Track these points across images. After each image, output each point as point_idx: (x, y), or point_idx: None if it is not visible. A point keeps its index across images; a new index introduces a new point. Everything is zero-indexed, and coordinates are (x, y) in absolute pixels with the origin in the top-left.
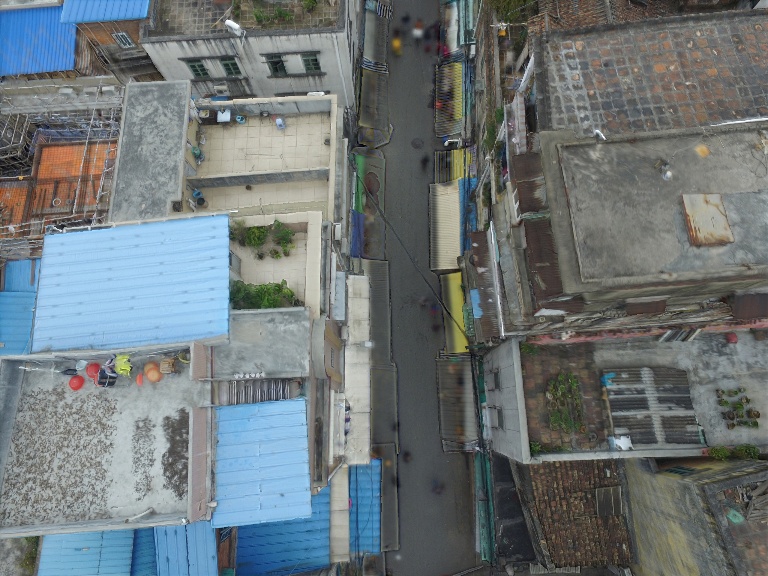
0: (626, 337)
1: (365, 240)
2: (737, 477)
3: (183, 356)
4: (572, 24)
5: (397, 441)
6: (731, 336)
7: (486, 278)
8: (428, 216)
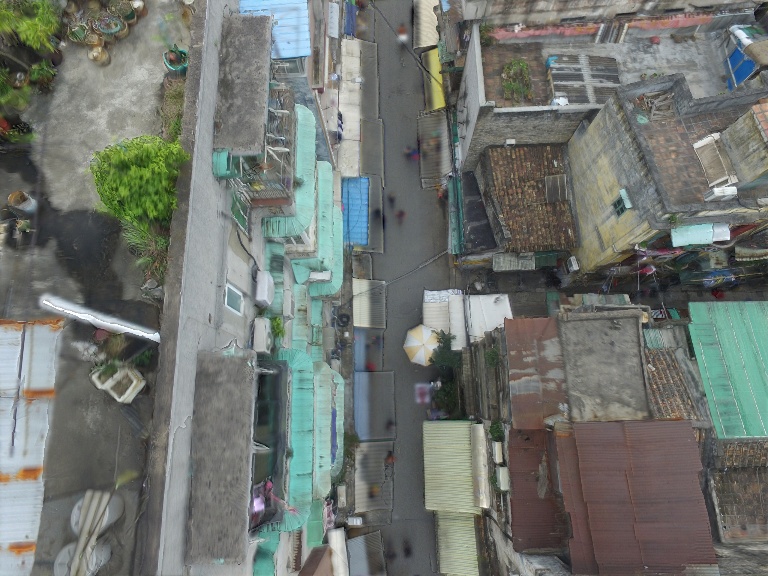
0: (568, 34)
1: (357, 26)
2: (642, 81)
3: None
4: None
5: (383, 177)
6: (654, 38)
7: None
8: (412, 10)
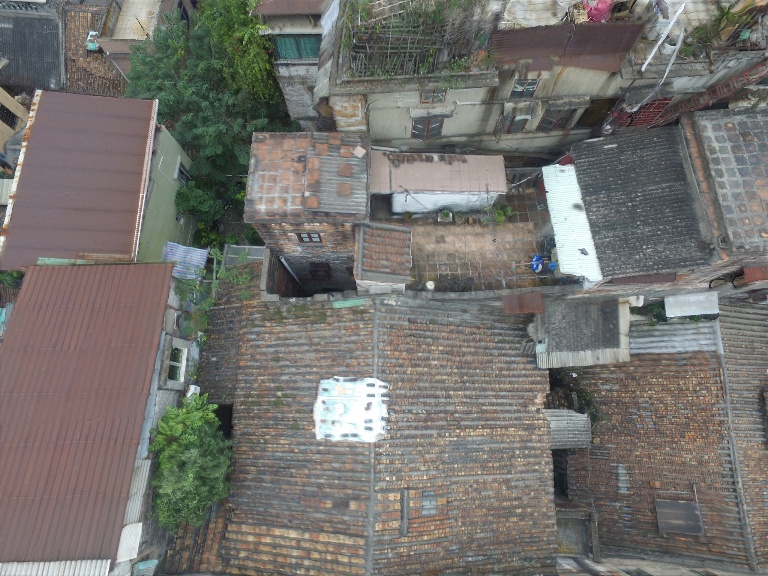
0: None
1: None
2: None
3: None
4: (765, 464)
5: None
6: None
7: None
8: None
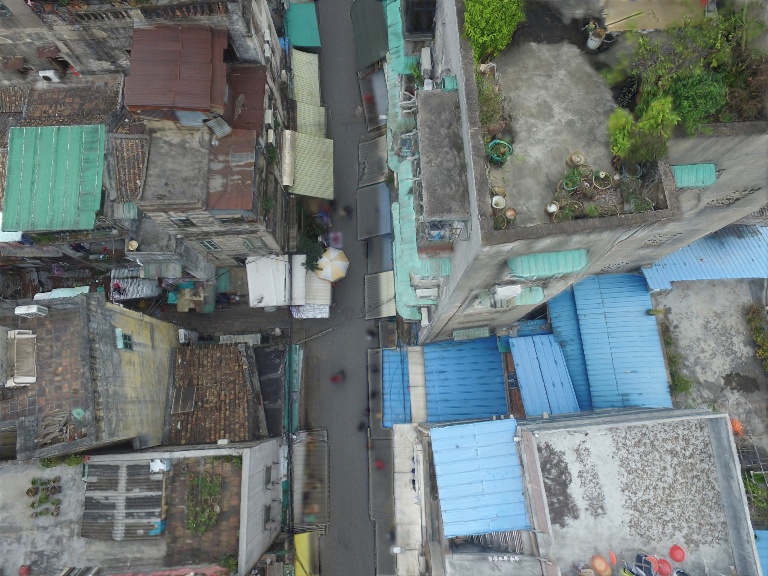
0: (129, 574)
1: None
2: None
3: None
4: None
5: (369, 440)
6: (25, 574)
7: None
8: None
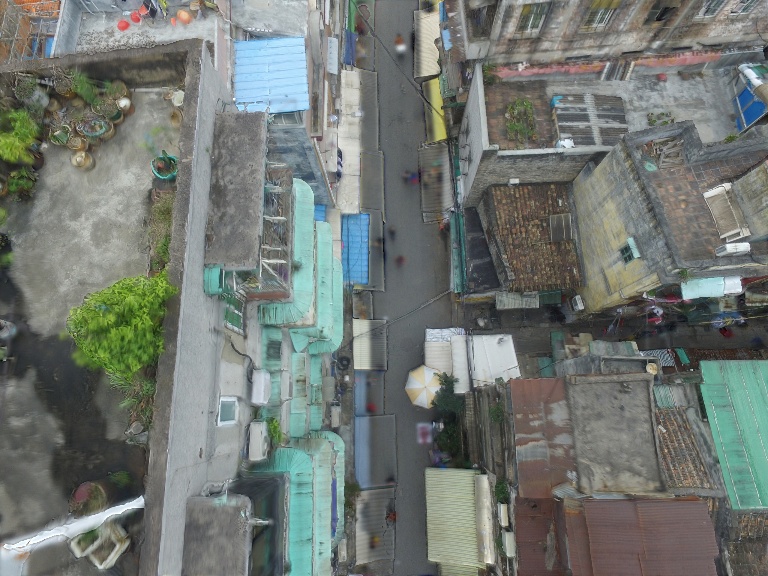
0: (573, 72)
1: (357, 54)
2: None
3: (208, 1)
4: None
5: (383, 212)
6: (661, 75)
7: (455, 20)
8: None
